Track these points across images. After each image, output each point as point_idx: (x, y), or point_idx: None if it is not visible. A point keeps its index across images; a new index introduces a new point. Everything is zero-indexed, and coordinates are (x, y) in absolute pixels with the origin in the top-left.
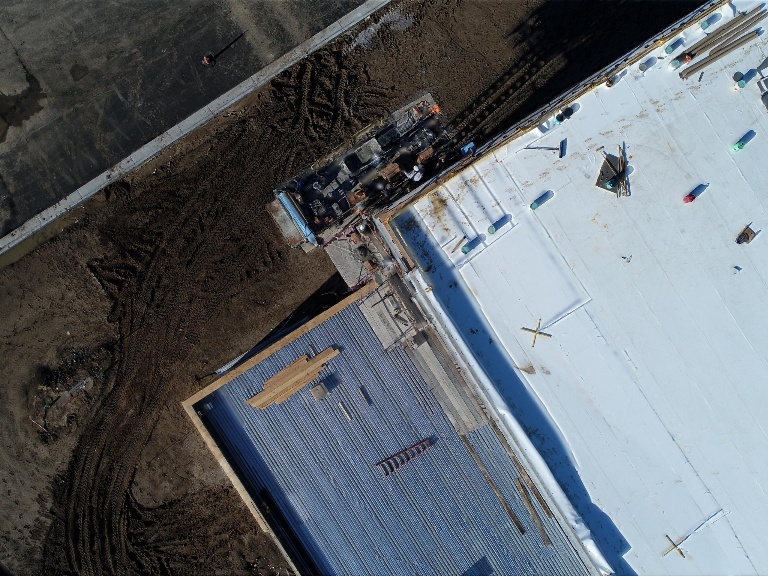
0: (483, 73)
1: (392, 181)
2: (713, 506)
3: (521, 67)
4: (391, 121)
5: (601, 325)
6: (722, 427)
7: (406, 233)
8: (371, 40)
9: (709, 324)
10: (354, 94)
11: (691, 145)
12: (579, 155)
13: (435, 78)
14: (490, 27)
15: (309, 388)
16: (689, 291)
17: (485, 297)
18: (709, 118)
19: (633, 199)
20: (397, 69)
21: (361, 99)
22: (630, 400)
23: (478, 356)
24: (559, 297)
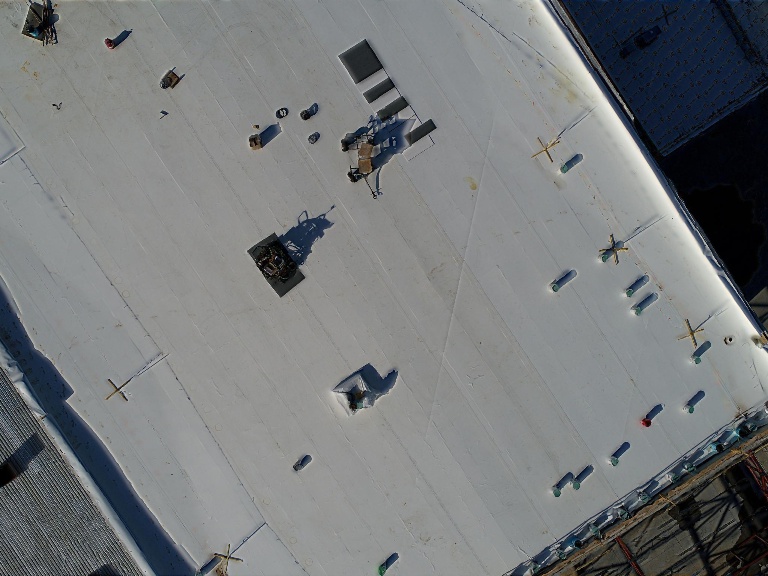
0: None
1: None
2: (153, 349)
3: None
4: None
5: (36, 172)
6: (158, 271)
7: None
8: None
9: (140, 169)
10: None
11: None
12: (6, 4)
13: None
14: None
15: None
16: (119, 137)
17: None
18: None
19: (60, 47)
20: None
21: None
22: (68, 246)
23: None
24: None
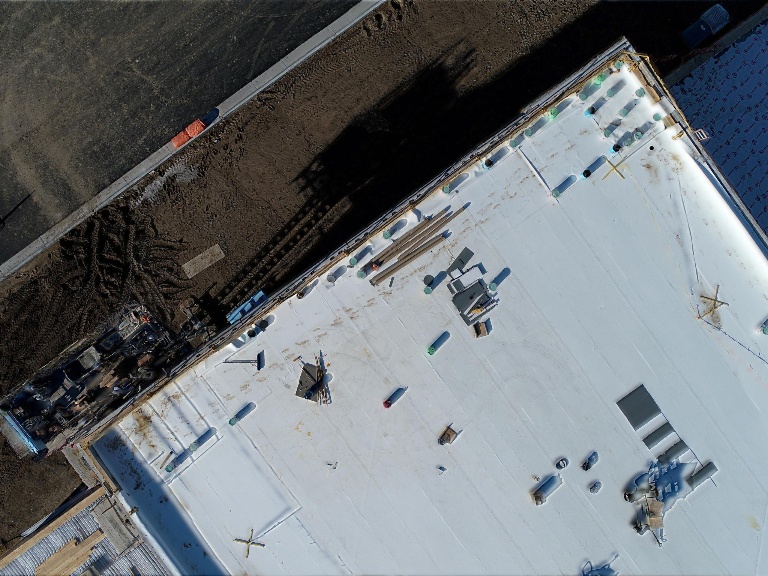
0: (269, 221)
1: (117, 385)
2: None
3: (307, 212)
4: (181, 274)
5: (313, 532)
6: None
7: (112, 452)
8: (158, 193)
9: (419, 525)
10: (143, 248)
11: (387, 350)
12: (278, 366)
13: (222, 228)
14: (274, 175)
15: (80, 572)
16: (397, 494)
17: (196, 511)
18: (402, 322)
19: (334, 406)
20: (184, 221)
21: (150, 253)
22: None
23: (193, 570)
24: (269, 507)
